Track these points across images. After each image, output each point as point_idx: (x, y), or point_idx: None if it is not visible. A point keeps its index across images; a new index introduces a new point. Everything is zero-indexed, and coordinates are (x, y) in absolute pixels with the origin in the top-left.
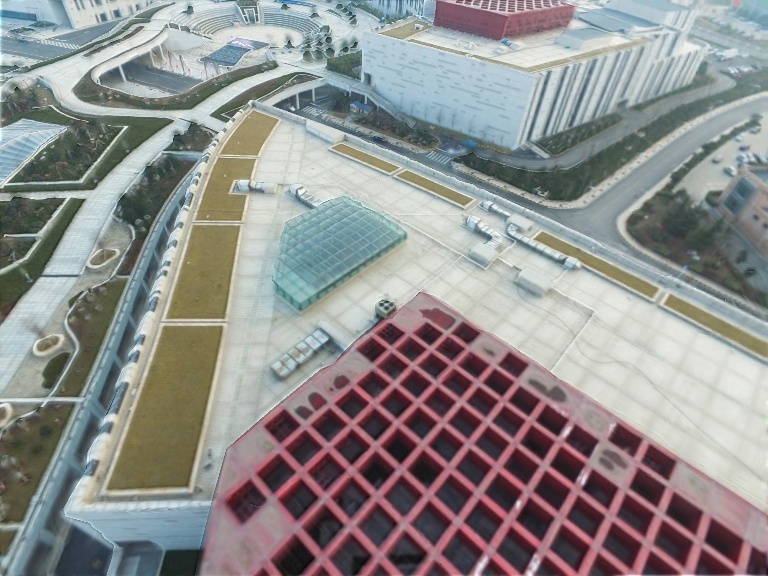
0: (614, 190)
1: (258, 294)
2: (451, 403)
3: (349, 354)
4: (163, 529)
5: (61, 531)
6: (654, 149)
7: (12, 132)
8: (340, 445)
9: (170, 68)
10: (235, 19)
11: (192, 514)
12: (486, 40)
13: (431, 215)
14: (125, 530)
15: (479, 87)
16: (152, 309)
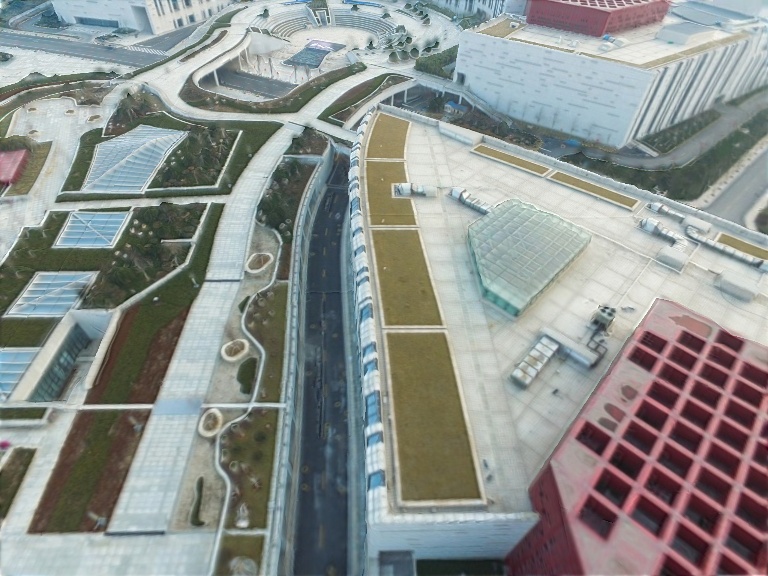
0: (732, 189)
1: (463, 300)
2: (752, 415)
3: (622, 363)
4: (442, 540)
5: (288, 537)
6: (761, 146)
7: (136, 138)
8: (662, 459)
9: (258, 72)
10: (307, 21)
11: (490, 526)
12: (585, 37)
13: (600, 217)
14: (405, 541)
15: (587, 85)
16: (371, 315)
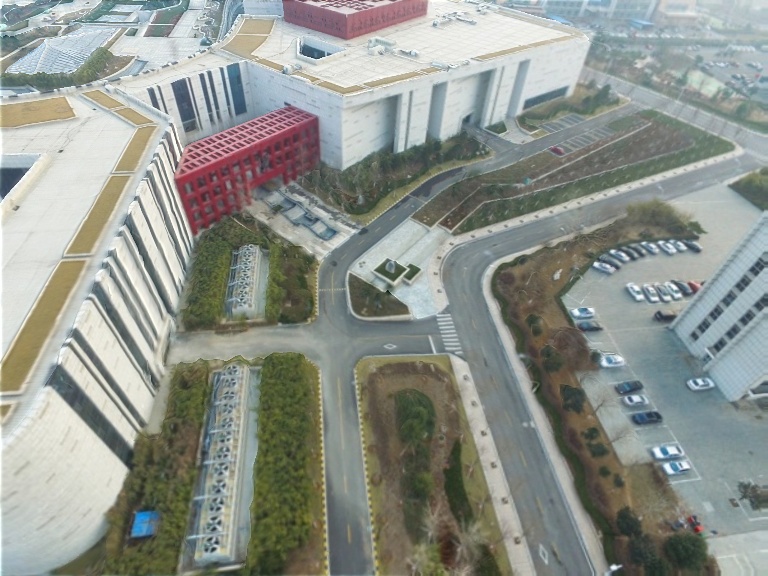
0: None
1: None
2: None
3: None
4: None
5: None
6: None
7: None
8: None
9: None
10: None
11: (274, 6)
12: None
13: None
14: None
15: None
16: None
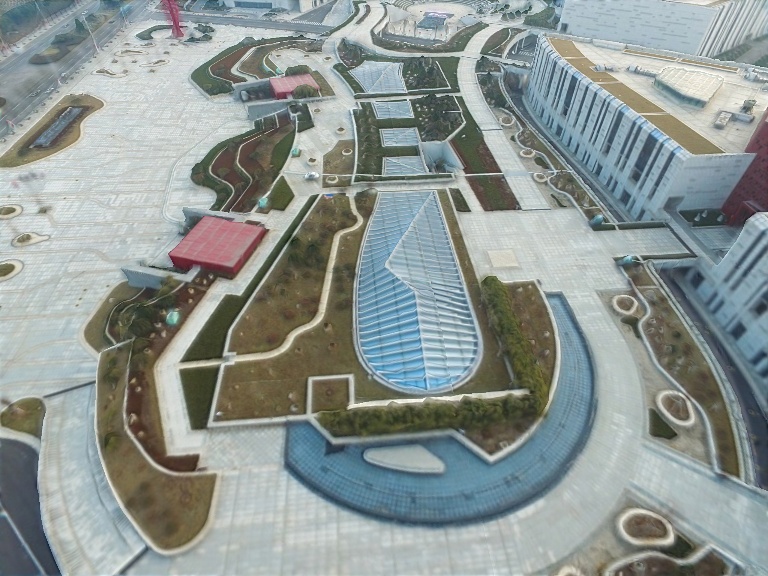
0: None
1: None
2: None
3: None
4: (704, 182)
5: None
6: None
7: (372, 66)
8: None
9: (402, 33)
10: None
11: (733, 163)
12: None
13: None
14: (688, 182)
15: (667, 22)
16: None
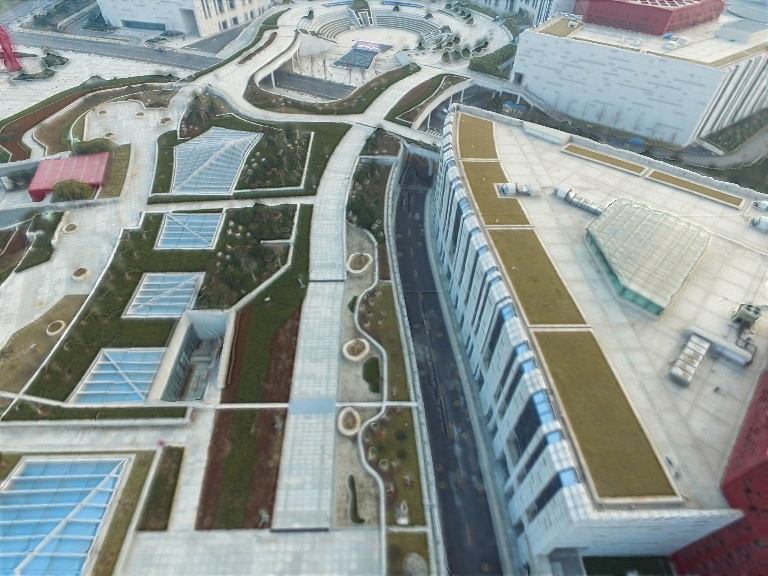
0: None
1: (598, 299)
2: None
3: None
4: (627, 537)
5: None
6: None
7: (212, 140)
8: None
9: (310, 73)
10: (350, 22)
11: (689, 523)
12: (646, 36)
13: (709, 216)
14: (591, 537)
15: (654, 84)
16: (515, 315)
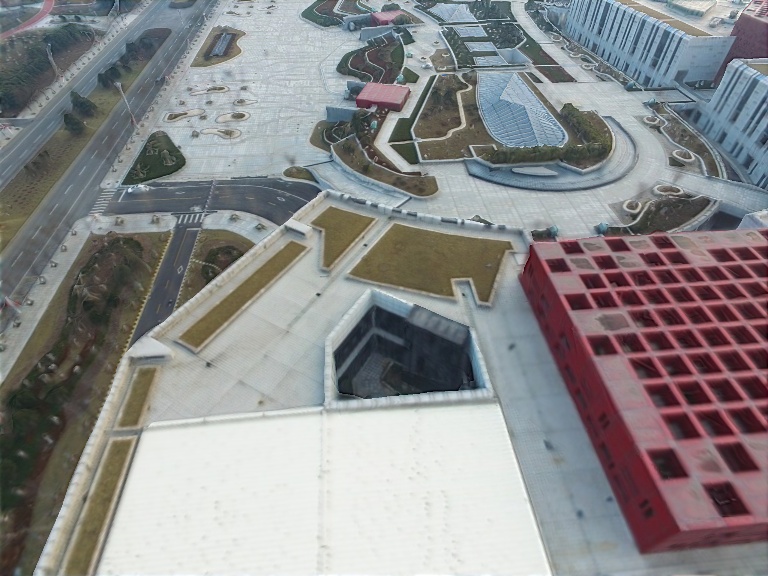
0: None
1: None
2: None
3: None
4: (702, 58)
5: None
6: None
7: (445, 6)
8: None
9: None
10: None
11: (721, 43)
12: None
13: None
14: (691, 58)
15: None
16: None
